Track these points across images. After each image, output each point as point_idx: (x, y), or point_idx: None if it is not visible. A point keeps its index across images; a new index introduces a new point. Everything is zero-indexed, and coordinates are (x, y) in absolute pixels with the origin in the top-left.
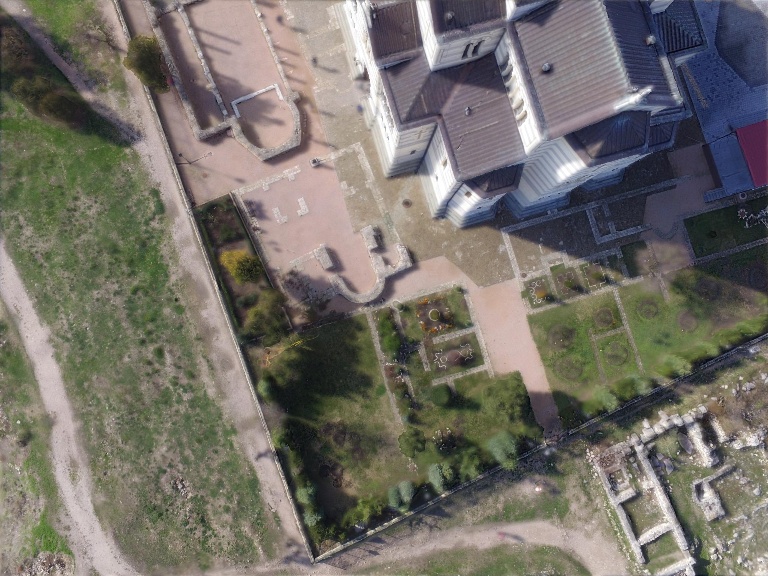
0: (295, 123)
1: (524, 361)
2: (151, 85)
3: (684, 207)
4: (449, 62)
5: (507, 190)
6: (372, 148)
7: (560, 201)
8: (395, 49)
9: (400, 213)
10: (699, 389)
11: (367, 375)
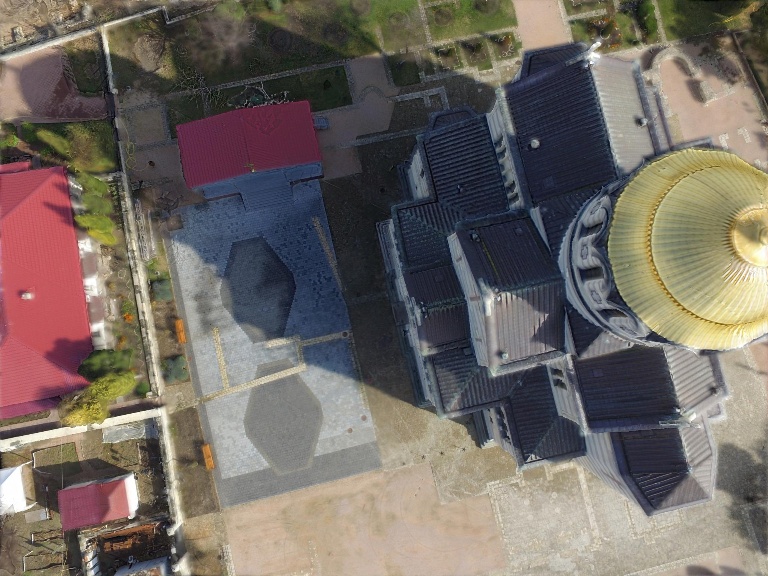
0: None
1: None
2: None
3: (350, 117)
4: None
5: None
6: None
7: None
8: None
9: None
10: None
11: None
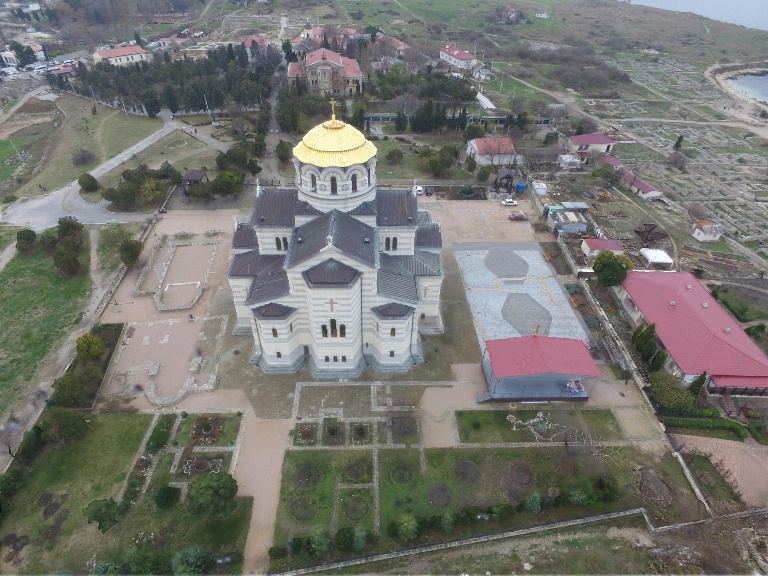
0: (195, 297)
1: (263, 489)
2: (125, 261)
3: (457, 402)
4: (269, 250)
5: (277, 318)
6: (234, 319)
7: (350, 372)
8: (246, 244)
9: (228, 357)
10: (435, 571)
11: (119, 461)
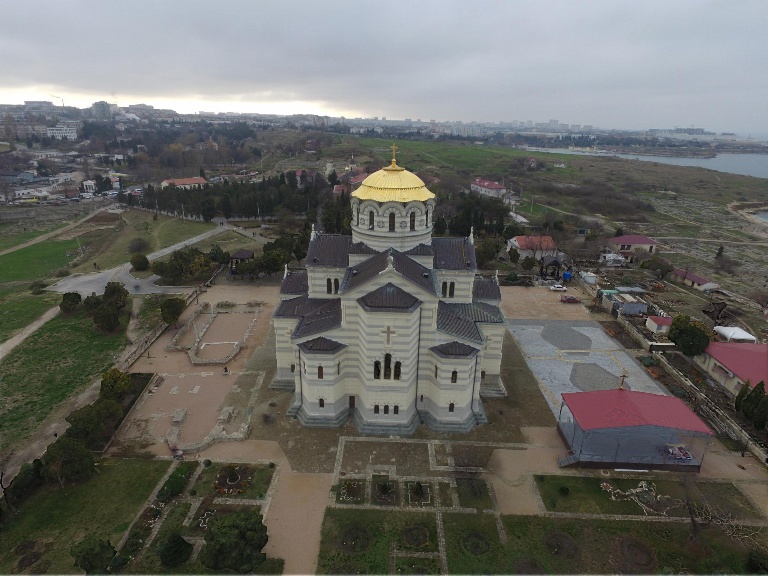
0: (231, 354)
1: (297, 551)
2: (165, 317)
3: (535, 466)
4: (319, 293)
5: (326, 352)
6: (272, 375)
7: (402, 428)
8: (294, 290)
9: (263, 409)
10: None
11: (123, 509)
